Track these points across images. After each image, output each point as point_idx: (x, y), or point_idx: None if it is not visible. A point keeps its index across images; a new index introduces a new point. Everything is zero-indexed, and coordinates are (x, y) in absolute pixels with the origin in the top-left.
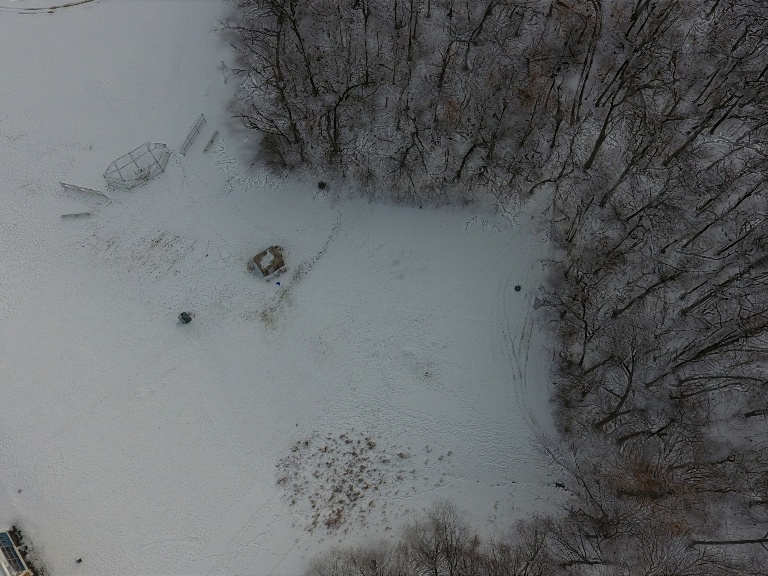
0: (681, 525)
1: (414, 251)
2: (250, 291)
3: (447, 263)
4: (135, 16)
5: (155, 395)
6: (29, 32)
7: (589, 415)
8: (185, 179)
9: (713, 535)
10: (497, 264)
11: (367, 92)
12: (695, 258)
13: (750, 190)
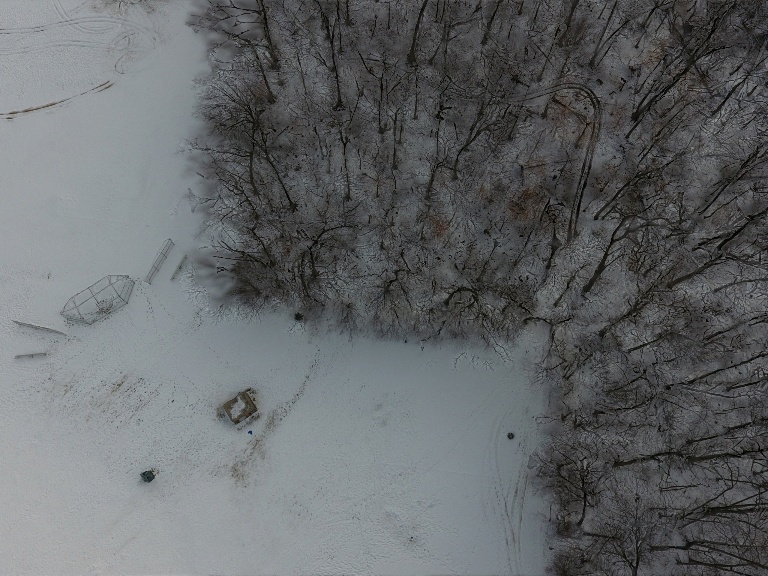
0: None
1: (398, 393)
2: (219, 442)
3: (434, 407)
4: (100, 122)
5: (113, 571)
6: None
7: None
8: (150, 311)
9: None
10: (488, 407)
11: (349, 206)
12: (703, 395)
13: (765, 352)
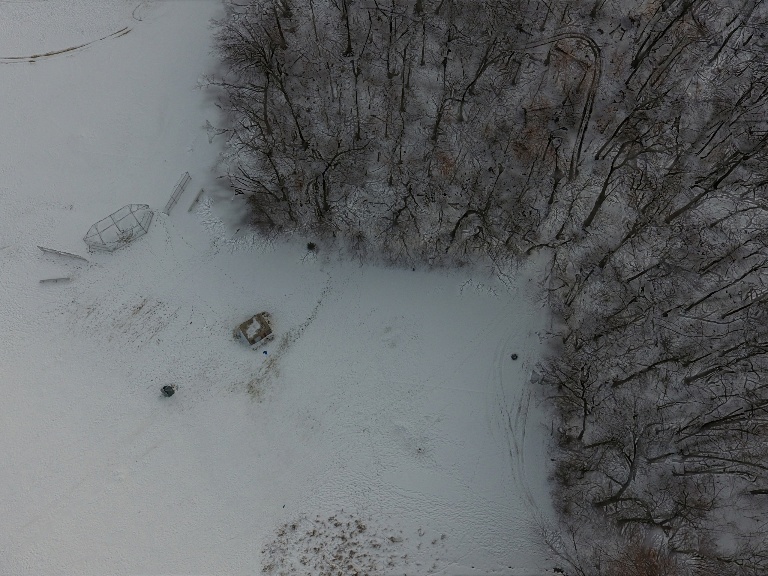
0: None
1: (407, 317)
2: (236, 361)
3: (441, 330)
4: (119, 65)
5: (135, 476)
6: (8, 83)
7: (589, 494)
8: (169, 240)
9: None
10: (493, 331)
11: (358, 145)
12: (698, 322)
13: (757, 265)
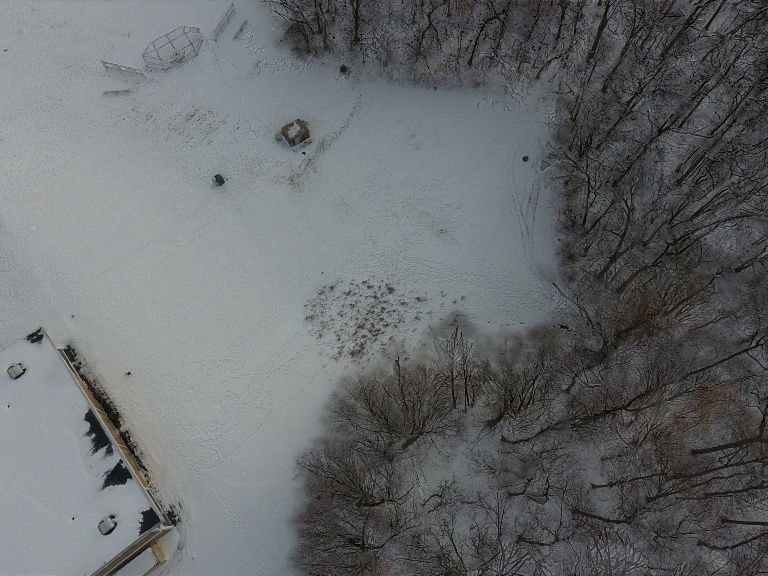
0: (675, 360)
1: (429, 126)
2: (278, 159)
3: (460, 137)
4: None
5: (193, 244)
6: None
7: (591, 268)
8: (217, 62)
9: (704, 362)
10: (506, 138)
11: None
12: (690, 137)
13: (740, 51)
